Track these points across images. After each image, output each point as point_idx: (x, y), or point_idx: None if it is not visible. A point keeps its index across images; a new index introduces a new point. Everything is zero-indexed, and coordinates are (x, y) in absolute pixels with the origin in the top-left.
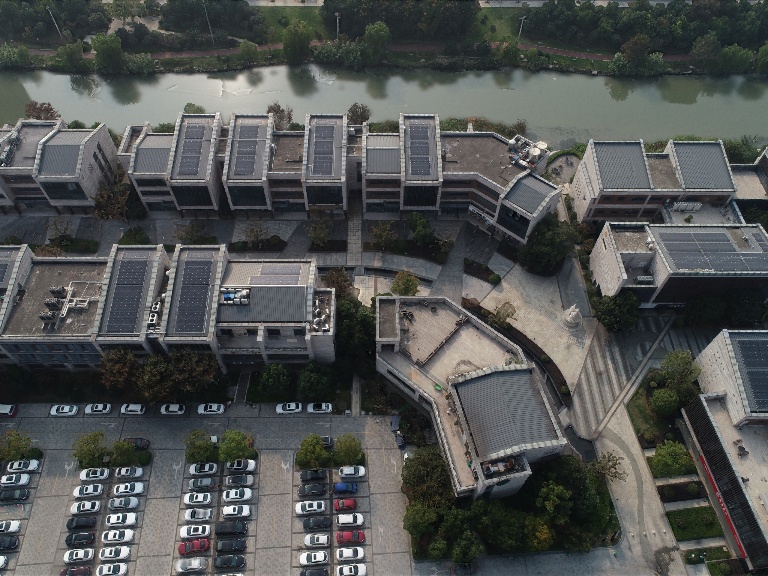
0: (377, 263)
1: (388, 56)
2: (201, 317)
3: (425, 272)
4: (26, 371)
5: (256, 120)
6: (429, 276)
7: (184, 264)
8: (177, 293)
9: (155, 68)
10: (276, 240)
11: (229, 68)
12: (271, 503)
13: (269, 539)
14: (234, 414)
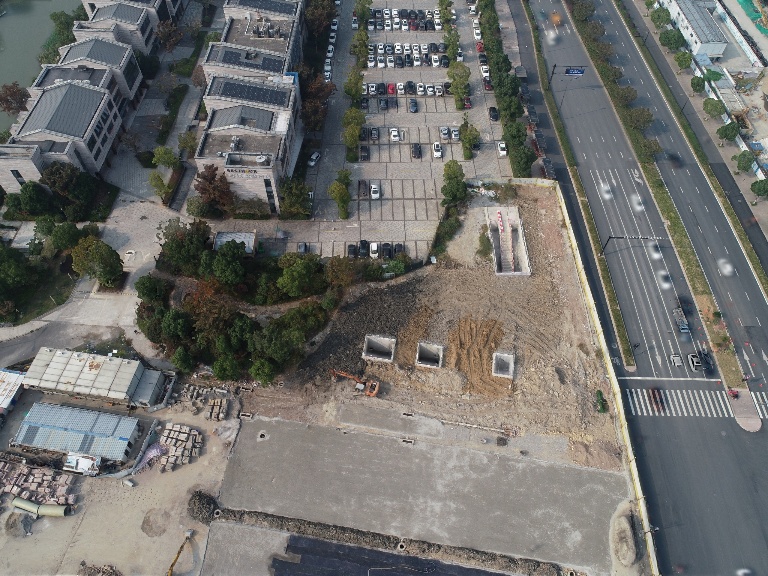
0: None
1: None
2: None
3: None
4: None
5: None
6: None
7: None
8: None
9: None
10: None
11: None
12: (391, 6)
13: (409, 6)
14: (338, 19)
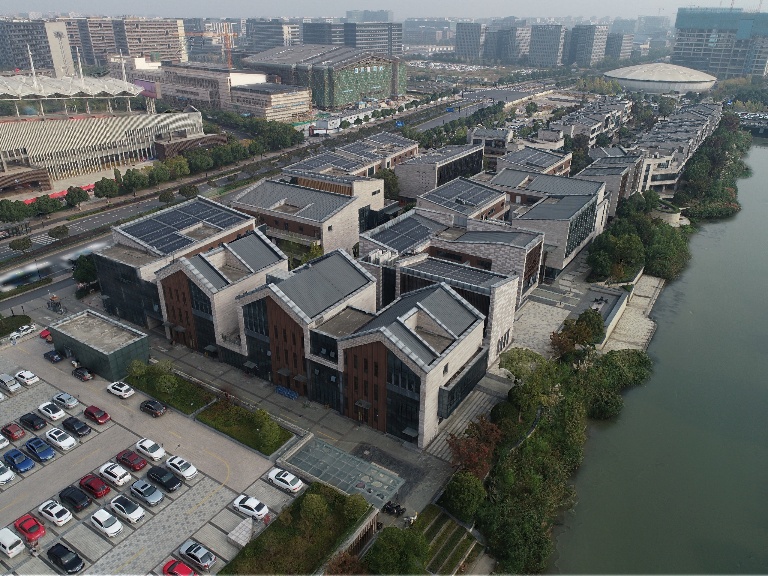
0: None
1: None
2: None
3: None
4: None
5: None
6: None
7: None
8: None
9: None
10: None
11: None
12: None
13: None
14: None
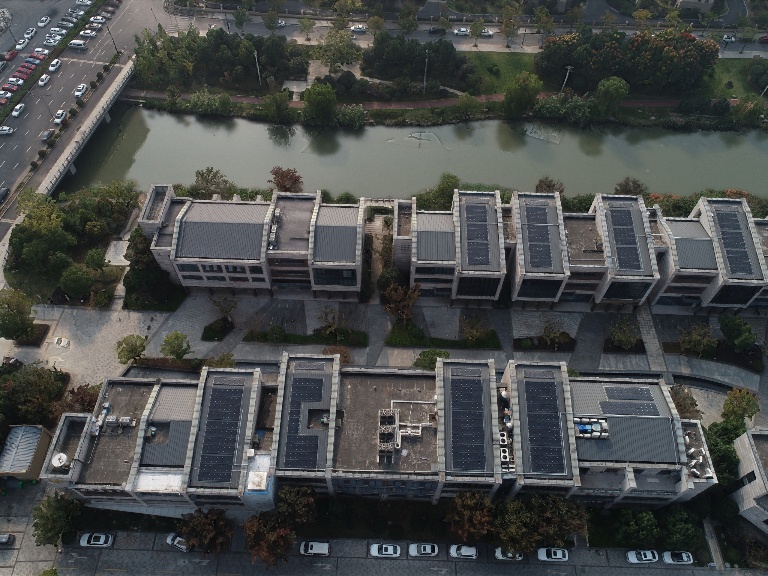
0: (685, 369)
1: (616, 112)
2: (559, 454)
3: (743, 382)
4: (343, 504)
5: (541, 200)
6: (749, 388)
7: (524, 385)
8: (524, 422)
9: (364, 120)
10: (567, 338)
11: (444, 122)
12: None
13: None
14: (579, 561)
